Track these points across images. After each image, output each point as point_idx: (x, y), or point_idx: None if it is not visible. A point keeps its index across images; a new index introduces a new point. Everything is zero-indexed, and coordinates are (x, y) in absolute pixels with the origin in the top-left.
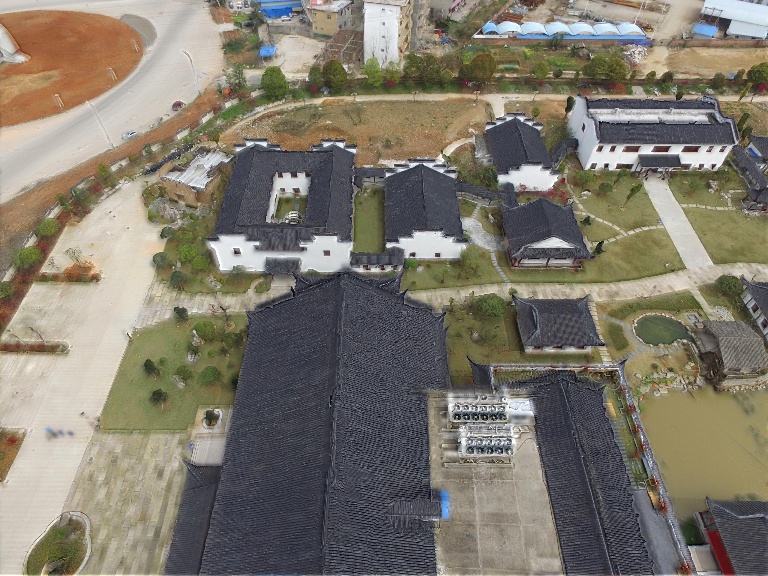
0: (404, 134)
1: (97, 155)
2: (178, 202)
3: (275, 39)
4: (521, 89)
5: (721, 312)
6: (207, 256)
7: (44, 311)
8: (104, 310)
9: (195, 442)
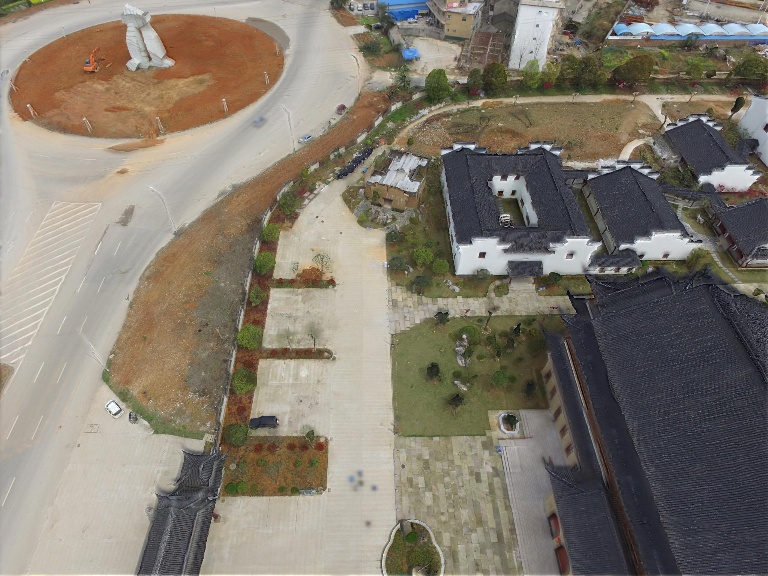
0: (579, 136)
1: (280, 160)
2: (382, 206)
3: (408, 41)
4: (673, 90)
5: None
6: (446, 261)
7: (293, 318)
8: (352, 316)
9: (500, 447)
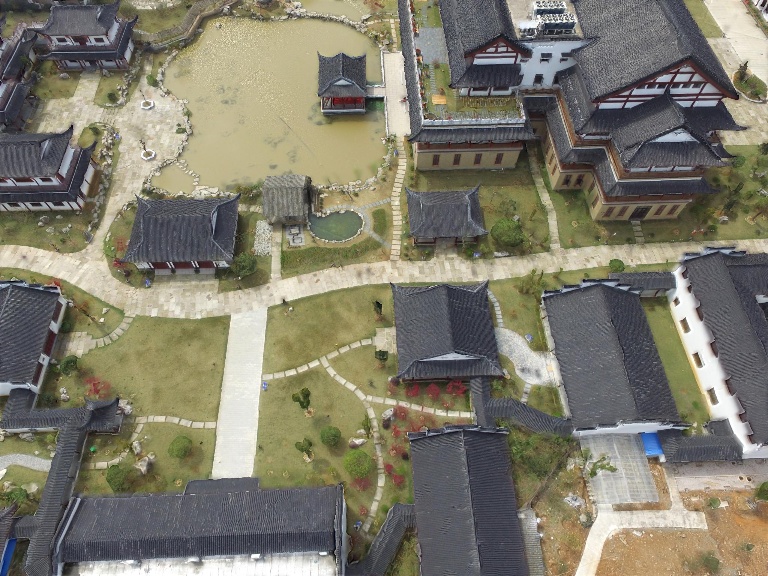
0: None
1: None
2: None
3: None
4: None
5: (265, 246)
6: None
7: None
8: None
9: None
